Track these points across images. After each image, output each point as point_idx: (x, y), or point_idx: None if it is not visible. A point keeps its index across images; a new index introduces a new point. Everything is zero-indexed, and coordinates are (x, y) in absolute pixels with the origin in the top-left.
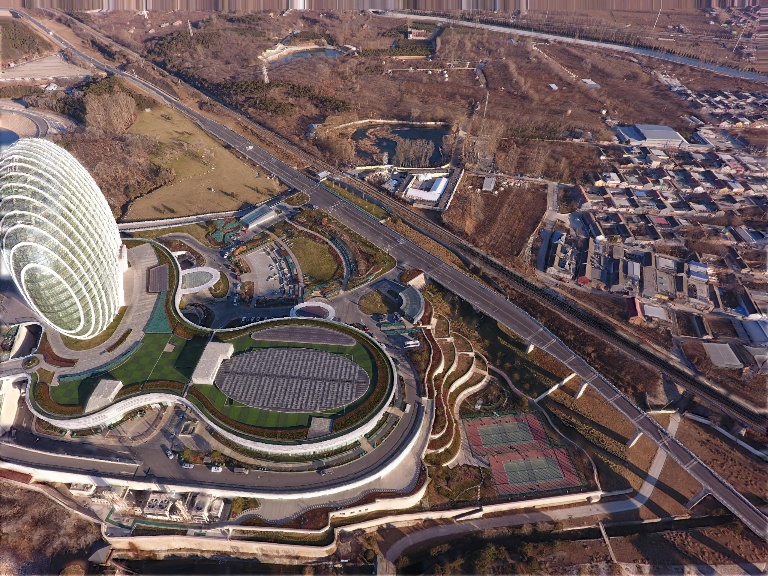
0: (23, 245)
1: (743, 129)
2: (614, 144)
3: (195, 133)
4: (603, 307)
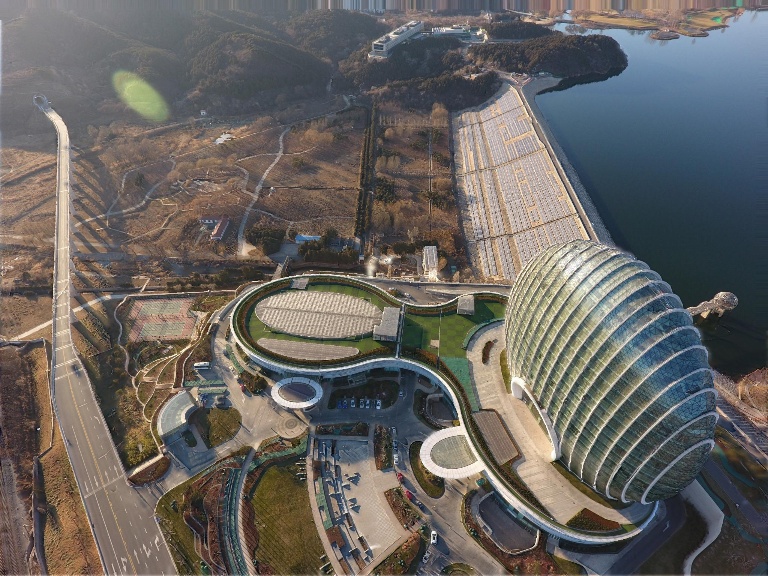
0: None
1: None
2: None
3: None
4: None
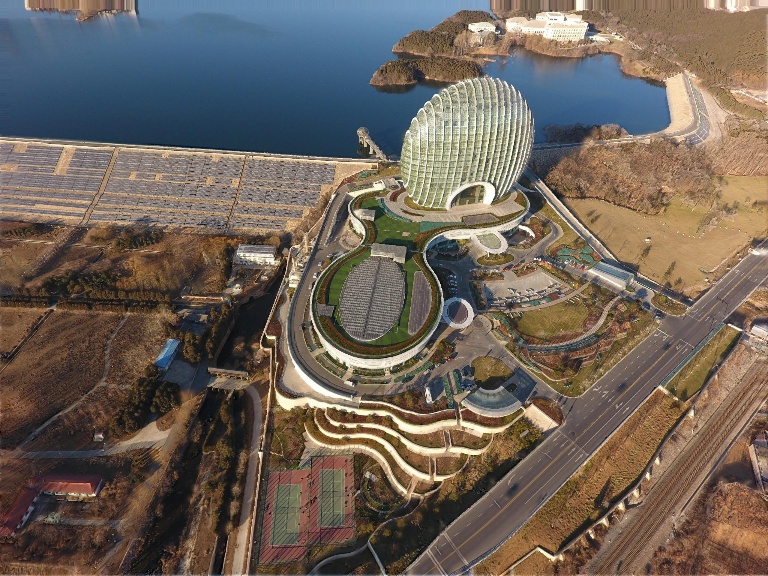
0: (416, 120)
1: None
2: None
3: (765, 215)
4: None
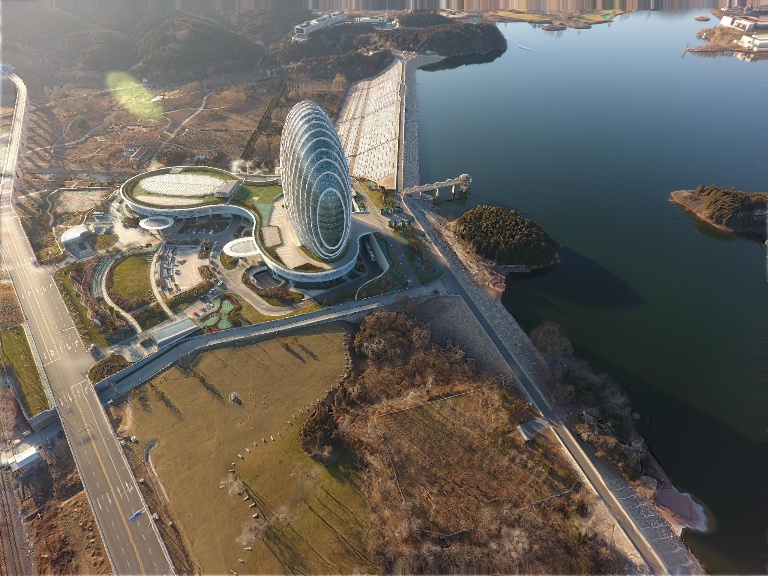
0: None
1: None
2: None
3: None
4: None
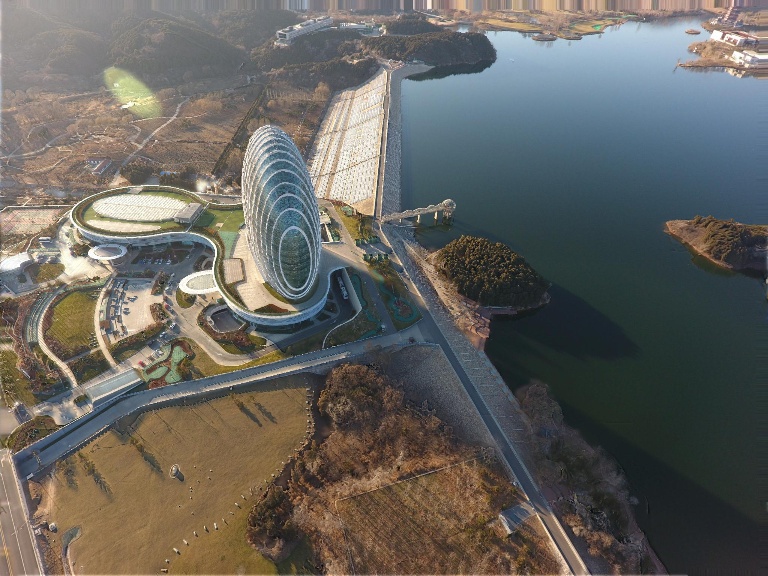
0: None
1: None
2: None
3: None
4: None
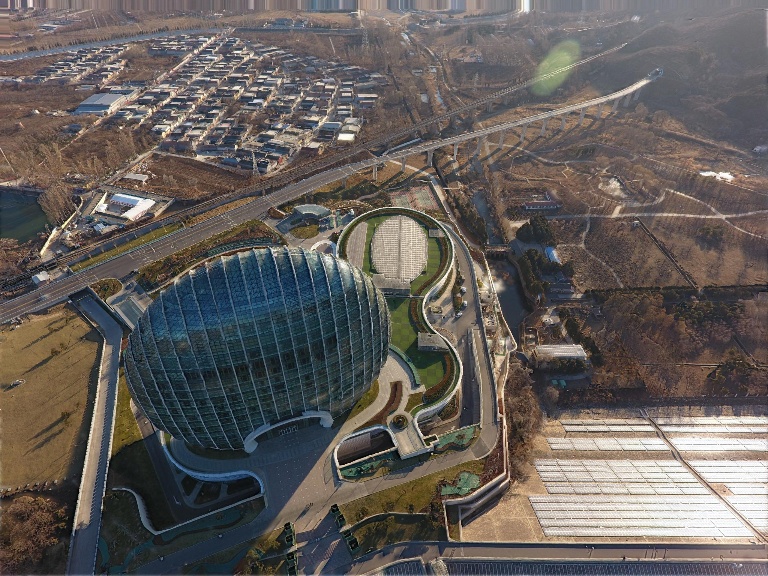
0: None
1: (115, 78)
2: (106, 118)
3: None
4: (309, 158)
